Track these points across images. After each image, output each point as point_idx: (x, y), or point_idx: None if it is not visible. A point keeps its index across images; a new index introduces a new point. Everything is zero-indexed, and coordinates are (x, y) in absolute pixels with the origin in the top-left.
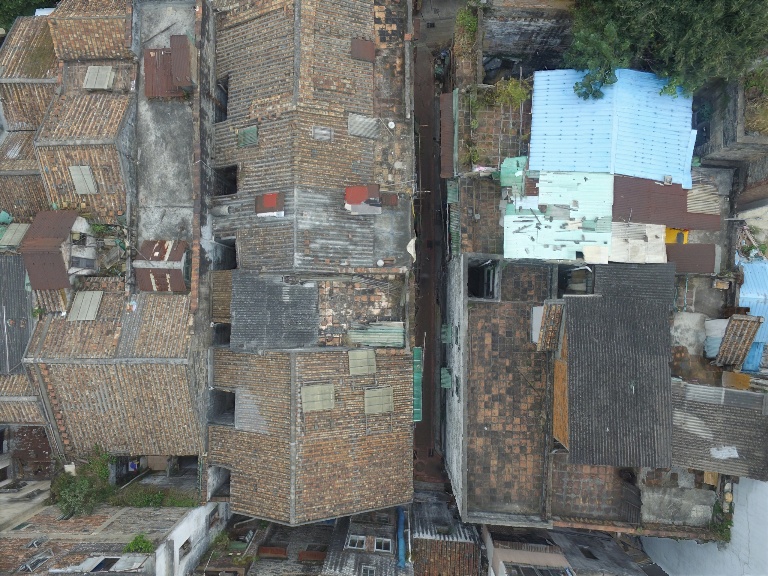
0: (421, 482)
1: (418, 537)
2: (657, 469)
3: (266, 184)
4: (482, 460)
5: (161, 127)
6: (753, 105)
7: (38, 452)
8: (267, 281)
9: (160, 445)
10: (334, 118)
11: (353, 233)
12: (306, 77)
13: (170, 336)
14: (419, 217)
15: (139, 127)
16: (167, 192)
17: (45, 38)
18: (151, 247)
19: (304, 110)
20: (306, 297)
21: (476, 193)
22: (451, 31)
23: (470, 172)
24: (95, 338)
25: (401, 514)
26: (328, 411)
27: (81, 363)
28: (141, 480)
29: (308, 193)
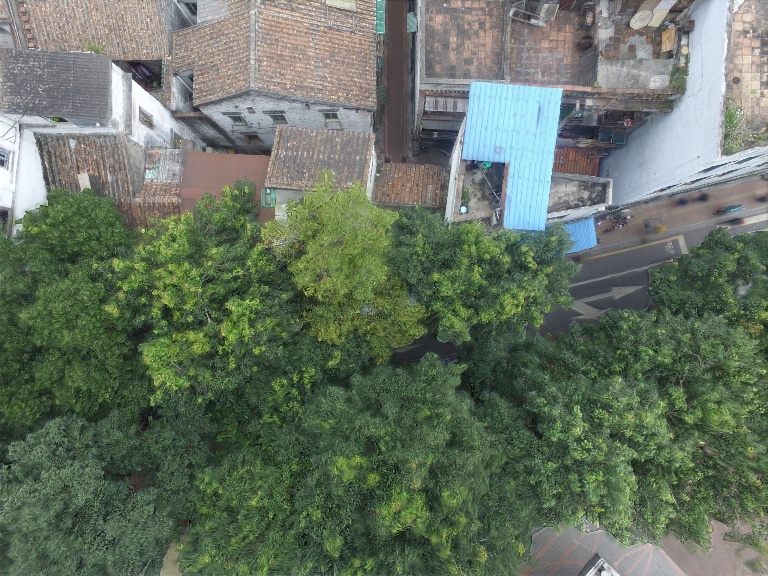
0: None
1: None
2: (615, 41)
3: None
4: (441, 37)
5: None
6: None
7: None
8: None
9: (124, 46)
10: None
11: None
12: None
13: None
14: None
15: None
16: None
17: None
18: None
19: None
20: None
21: None
22: None
23: None
24: None
25: None
26: None
27: None
28: None
29: None
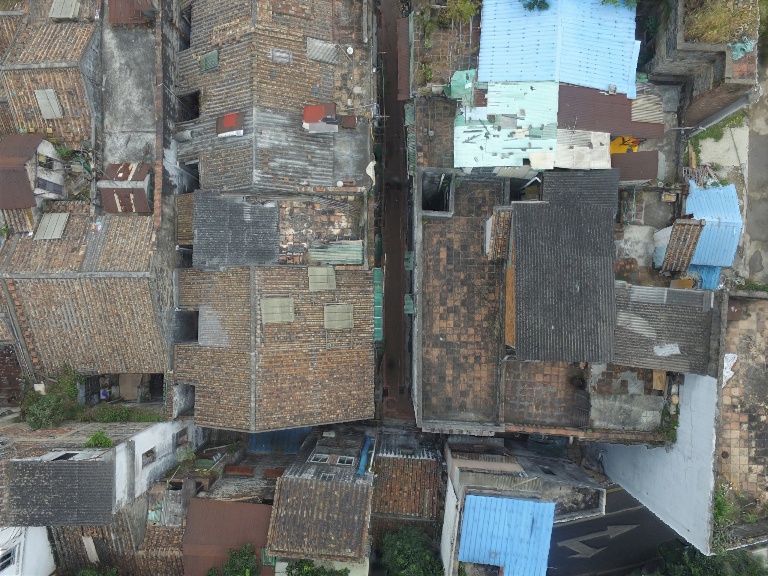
0: (392, 419)
1: (381, 455)
2: (608, 376)
3: (227, 106)
4: (438, 370)
5: (125, 54)
6: (694, 15)
7: (11, 379)
8: (228, 201)
9: (126, 362)
10: (293, 42)
11: (312, 154)
12: (264, 1)
13: (133, 252)
14: (383, 151)
15: (104, 54)
16: (132, 118)
17: None
18: (115, 169)
19: (262, 32)
20: (267, 217)
21: (431, 113)
22: None
23: (422, 87)
24: (60, 255)
25: (367, 440)
26: (288, 324)
27: (46, 277)
28: None
29: (267, 113)
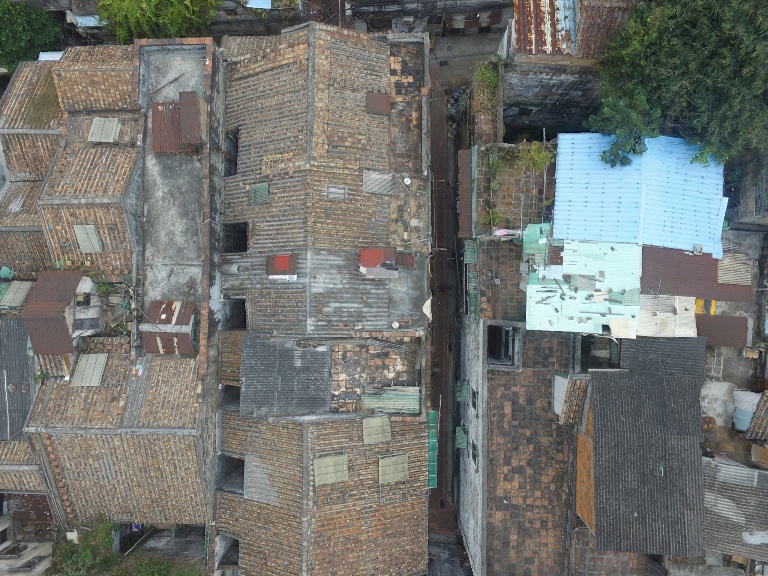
0: (432, 534)
1: None
2: None
3: (278, 244)
4: (501, 535)
5: (169, 182)
6: None
7: (39, 513)
8: (278, 345)
9: (166, 514)
10: (348, 175)
11: (367, 295)
12: (320, 134)
13: (177, 404)
14: (433, 268)
15: (146, 182)
16: (175, 250)
17: (49, 85)
18: (158, 308)
19: (318, 169)
20: (318, 361)
21: (495, 255)
22: (464, 69)
23: (491, 237)
24: (99, 405)
25: None
26: (341, 482)
27: (85, 433)
28: (145, 543)
29: (321, 255)
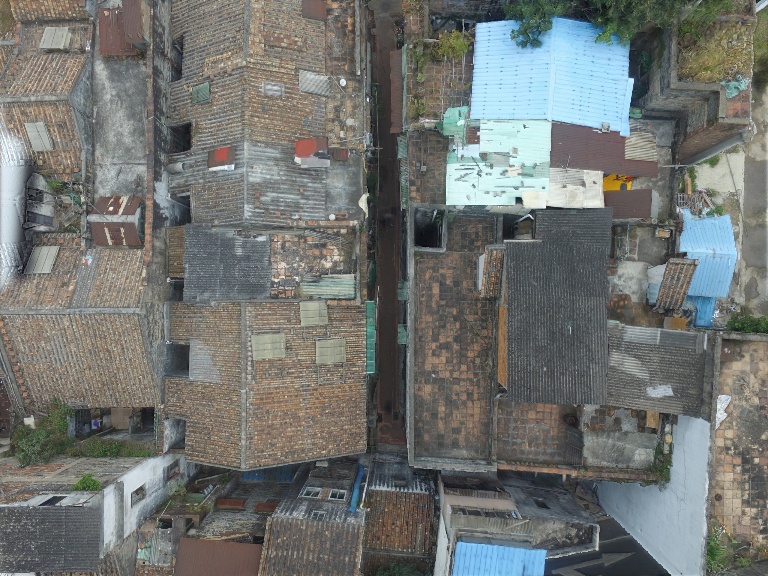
0: (386, 445)
1: (374, 489)
2: (601, 414)
3: (218, 139)
4: (430, 407)
5: (116, 86)
6: (688, 53)
7: (1, 410)
8: (220, 234)
9: (117, 397)
10: (285, 75)
11: (304, 187)
12: (256, 34)
13: (124, 288)
14: (377, 179)
15: (95, 86)
16: (123, 150)
17: (5, 2)
18: (106, 202)
19: (254, 66)
20: (259, 250)
21: (424, 147)
22: None
23: (415, 123)
24: (50, 290)
25: (361, 470)
26: (279, 360)
27: (35, 314)
28: (103, 436)
29: (258, 147)
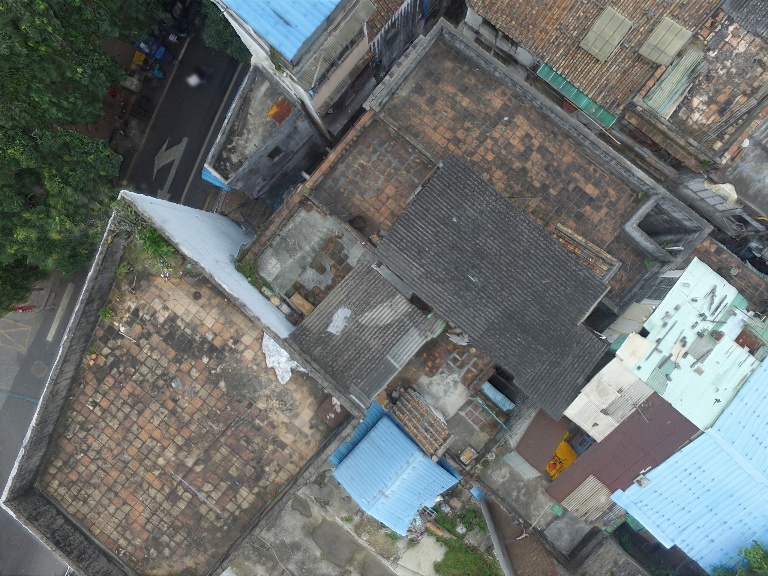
0: None
1: None
2: (341, 259)
3: None
4: (477, 91)
5: None
6: None
7: None
8: None
9: None
10: None
11: None
12: None
13: None
14: None
15: None
16: None
17: None
18: None
19: None
20: None
21: (747, 293)
22: None
23: None
24: None
25: None
26: None
27: None
28: None
29: None
